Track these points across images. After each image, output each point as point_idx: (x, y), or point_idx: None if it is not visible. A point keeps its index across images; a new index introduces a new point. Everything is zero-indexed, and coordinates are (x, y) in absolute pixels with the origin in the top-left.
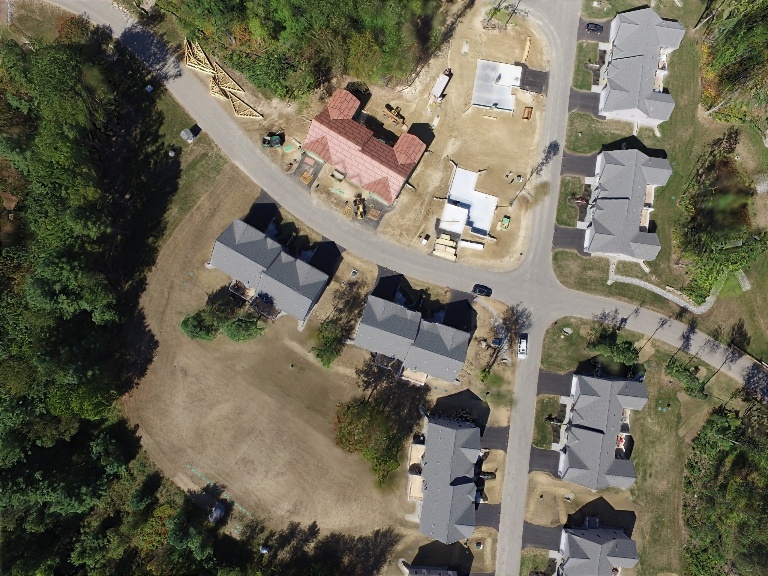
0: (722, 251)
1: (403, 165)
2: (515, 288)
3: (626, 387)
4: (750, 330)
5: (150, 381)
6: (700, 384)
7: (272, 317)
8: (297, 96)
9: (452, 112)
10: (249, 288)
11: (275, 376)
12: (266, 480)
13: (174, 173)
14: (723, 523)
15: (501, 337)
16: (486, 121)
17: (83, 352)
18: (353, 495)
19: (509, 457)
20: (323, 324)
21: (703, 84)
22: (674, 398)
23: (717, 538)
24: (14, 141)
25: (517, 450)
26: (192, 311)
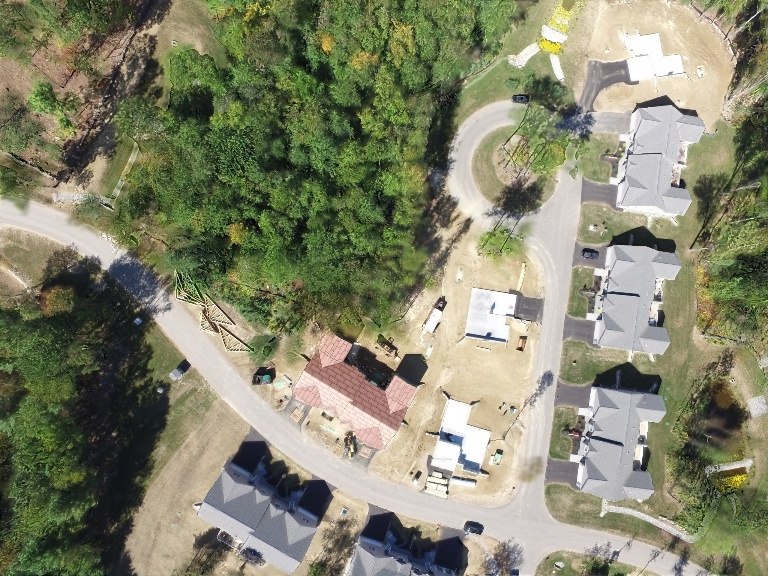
0: (715, 474)
1: (395, 413)
2: (507, 524)
3: None
4: (742, 557)
5: None
6: None
7: (260, 564)
8: (288, 329)
9: (445, 341)
10: None
11: None
12: None
13: (162, 409)
14: None
15: (492, 572)
16: (480, 352)
17: None
18: None
19: None
20: (312, 566)
21: (699, 306)
22: None
23: None
24: None
25: None
26: (179, 554)
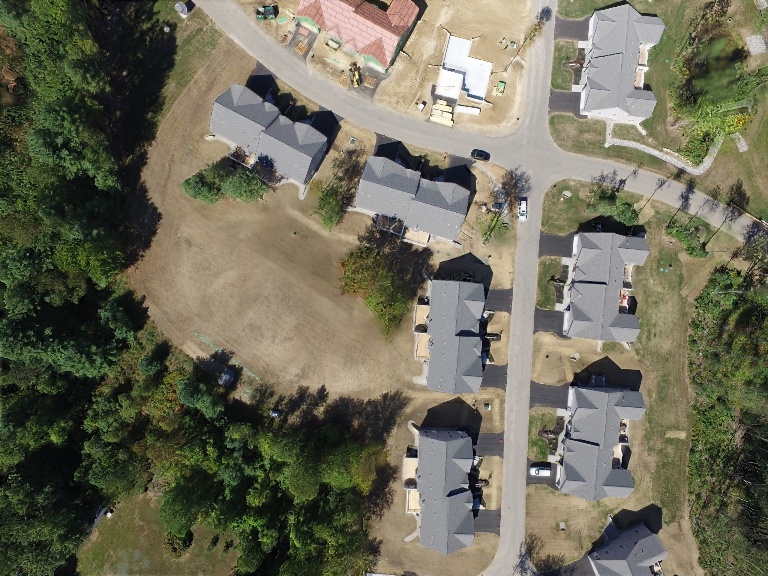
0: (718, 114)
1: (397, 26)
2: (513, 152)
3: (627, 241)
4: (749, 190)
5: (155, 253)
6: (701, 244)
7: (273, 184)
8: None
9: None
10: (249, 155)
11: (278, 243)
12: (273, 345)
13: (170, 49)
14: (729, 379)
15: (501, 202)
16: None
17: (87, 214)
18: (360, 358)
19: (513, 319)
20: (324, 192)
21: None
22: (675, 259)
23: (723, 393)
24: (10, 3)
25: (521, 312)
26: None
